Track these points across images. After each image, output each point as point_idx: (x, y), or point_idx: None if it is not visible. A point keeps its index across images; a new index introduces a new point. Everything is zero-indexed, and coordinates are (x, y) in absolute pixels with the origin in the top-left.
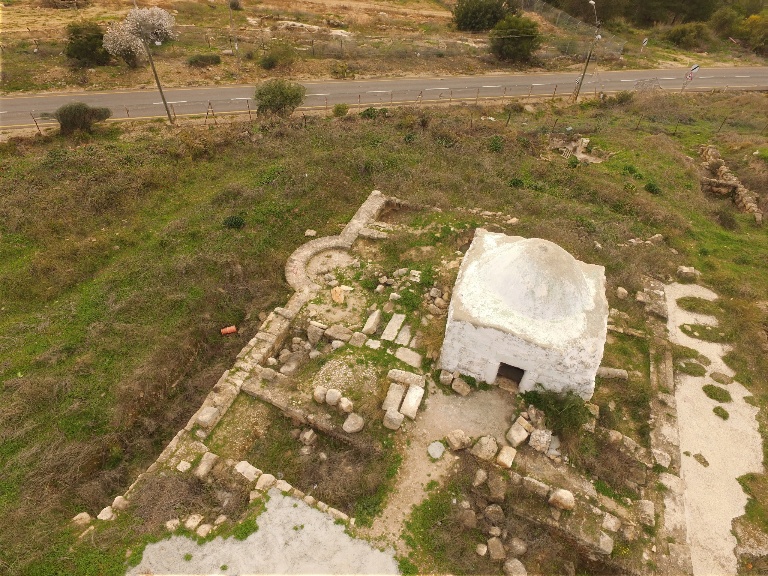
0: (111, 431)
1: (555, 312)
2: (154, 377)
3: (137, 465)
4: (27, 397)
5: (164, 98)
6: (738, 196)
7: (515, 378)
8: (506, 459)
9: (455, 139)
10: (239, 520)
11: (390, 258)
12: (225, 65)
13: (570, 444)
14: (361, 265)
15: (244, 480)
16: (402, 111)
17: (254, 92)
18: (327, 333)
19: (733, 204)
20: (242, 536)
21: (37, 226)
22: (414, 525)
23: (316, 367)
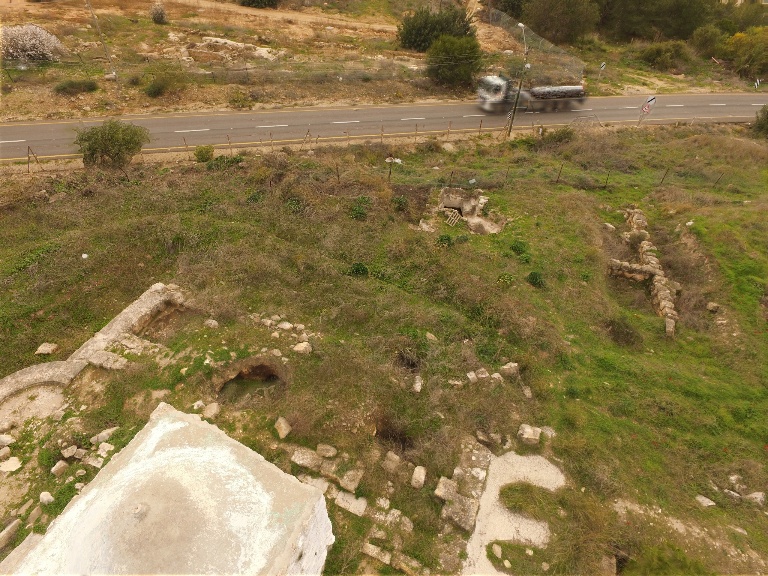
0: None
1: None
2: None
3: None
4: None
5: None
6: (654, 288)
7: None
8: None
9: (307, 202)
10: None
11: (111, 405)
12: (101, 93)
13: None
14: (64, 417)
15: None
16: (261, 160)
17: None
18: None
19: (649, 297)
20: None
21: None
22: None
23: None
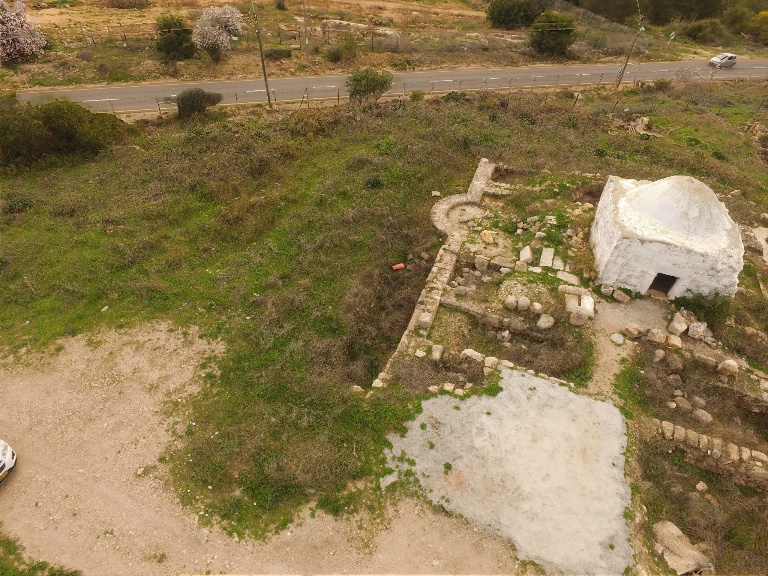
0: (347, 333)
1: (705, 229)
2: (362, 297)
3: (378, 356)
4: (281, 306)
5: (267, 84)
6: None
7: (661, 290)
8: (676, 342)
9: (535, 117)
10: (483, 386)
11: (518, 210)
12: (296, 58)
13: (722, 332)
14: (495, 215)
15: (475, 360)
16: (480, 95)
17: (344, 79)
18: (494, 262)
19: None
20: (494, 393)
21: (211, 187)
22: (620, 386)
23: (495, 286)
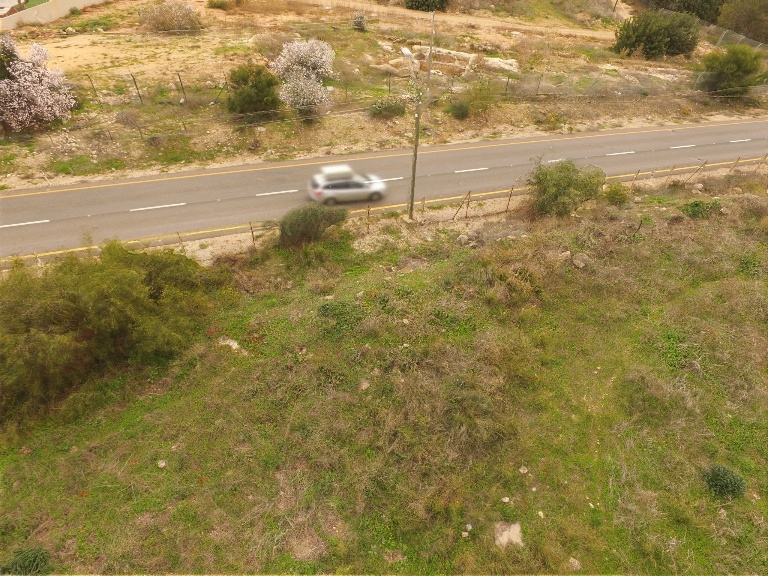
0: None
1: None
2: None
3: None
4: None
5: (413, 188)
6: None
7: None
8: None
9: None
10: None
11: None
12: (412, 116)
13: None
14: None
15: None
16: (741, 205)
17: (524, 175)
18: None
19: None
20: None
21: (418, 514)
22: None
23: None
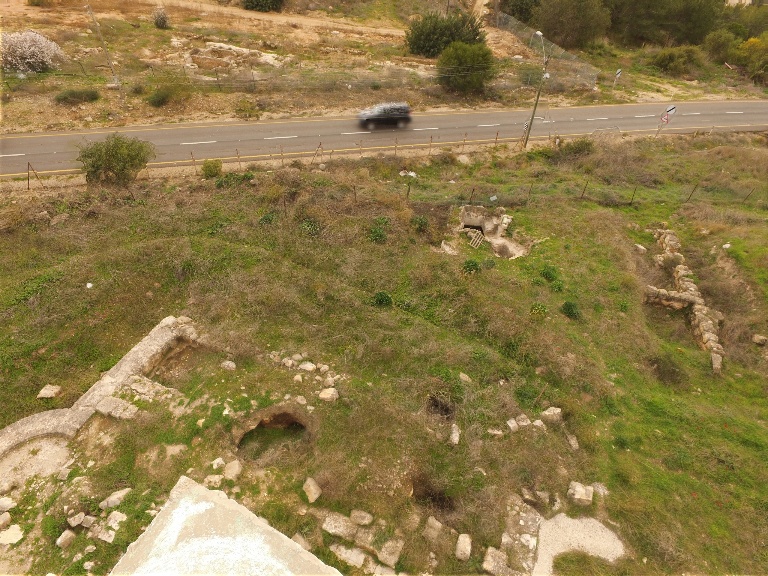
0: None
1: None
2: None
3: None
4: None
5: None
6: (694, 317)
7: None
8: None
9: (323, 223)
10: None
11: (121, 461)
12: (103, 102)
13: None
14: (69, 475)
15: None
16: (273, 177)
17: None
18: None
19: (688, 326)
20: None
21: None
22: None
23: None
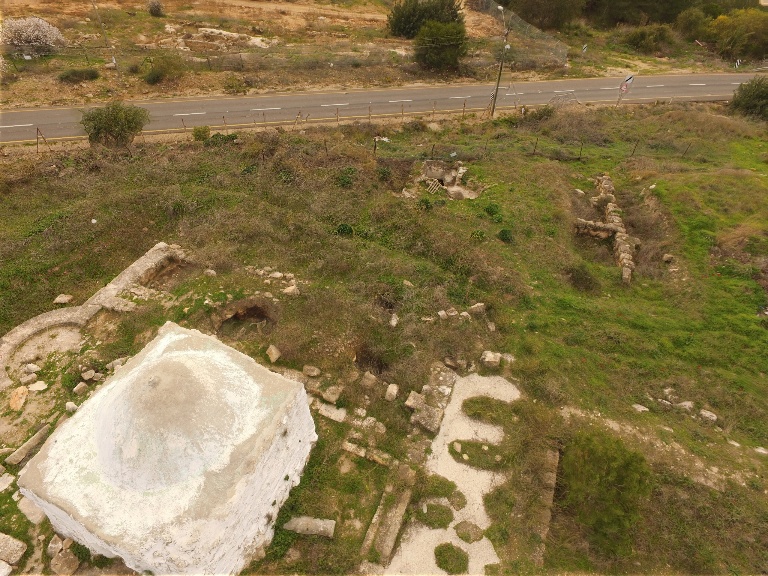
0: None
1: (151, 479)
2: None
3: None
4: None
5: None
6: (615, 243)
7: None
8: None
9: (297, 172)
10: None
11: (123, 340)
12: (102, 80)
13: None
14: (82, 350)
15: None
16: (254, 137)
17: None
18: None
19: (611, 252)
20: None
21: None
22: None
23: None
